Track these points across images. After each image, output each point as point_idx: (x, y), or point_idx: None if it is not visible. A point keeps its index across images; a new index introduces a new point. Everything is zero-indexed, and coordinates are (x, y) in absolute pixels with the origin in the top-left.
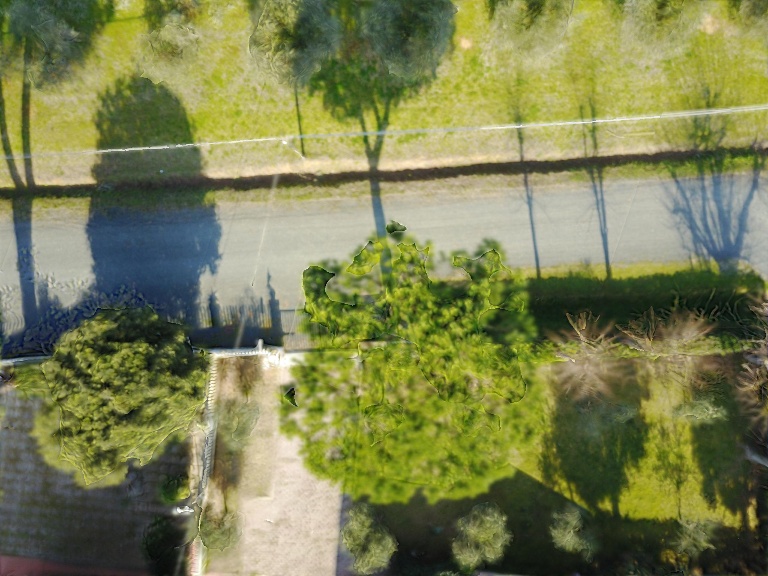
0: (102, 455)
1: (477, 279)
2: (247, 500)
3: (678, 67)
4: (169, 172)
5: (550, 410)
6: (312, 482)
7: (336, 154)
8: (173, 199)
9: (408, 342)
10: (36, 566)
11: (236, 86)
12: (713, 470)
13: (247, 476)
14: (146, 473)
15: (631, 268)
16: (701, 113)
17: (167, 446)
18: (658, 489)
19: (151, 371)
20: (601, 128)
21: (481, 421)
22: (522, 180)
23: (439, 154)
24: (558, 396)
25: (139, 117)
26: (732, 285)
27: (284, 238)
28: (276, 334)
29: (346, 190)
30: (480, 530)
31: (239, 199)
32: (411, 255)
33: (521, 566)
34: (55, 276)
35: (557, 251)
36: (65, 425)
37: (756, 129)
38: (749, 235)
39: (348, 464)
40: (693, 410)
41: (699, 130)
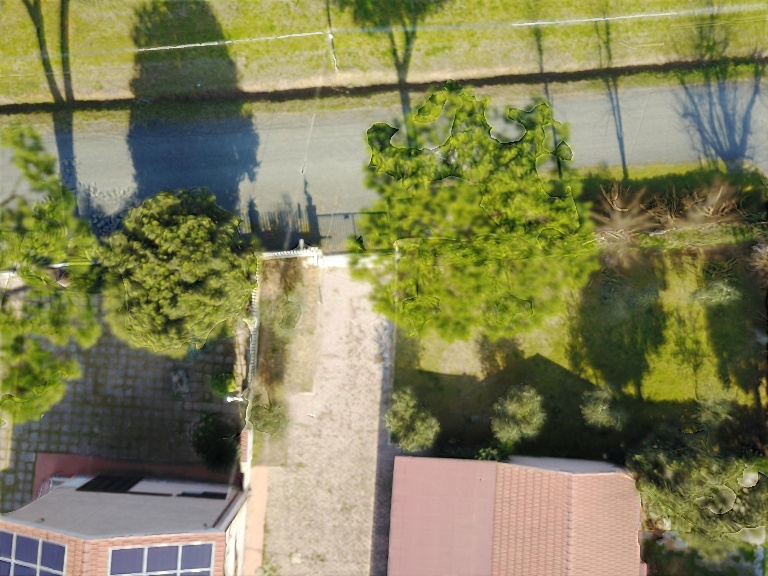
0: (168, 324)
1: (532, 127)
2: (289, 396)
3: None
4: (206, 86)
5: (575, 302)
6: (352, 377)
7: (367, 67)
8: (211, 111)
9: (442, 238)
10: (84, 466)
11: (270, 3)
12: (726, 352)
13: (289, 373)
14: (191, 373)
15: (646, 169)
16: (706, 24)
17: (211, 346)
18: (676, 372)
19: (214, 243)
20: (615, 40)
21: (514, 307)
22: (543, 89)
23: (465, 66)
24: (582, 289)
25: (176, 33)
26: (738, 183)
27: (319, 146)
28: (314, 238)
29: (378, 100)
30: (517, 405)
31: (275, 110)
32: (472, 104)
33: (551, 449)
34: (97, 186)
35: (577, 154)
36: (133, 295)
37: (756, 39)
38: (752, 136)
39: (386, 359)
40: (709, 290)
41: (704, 40)
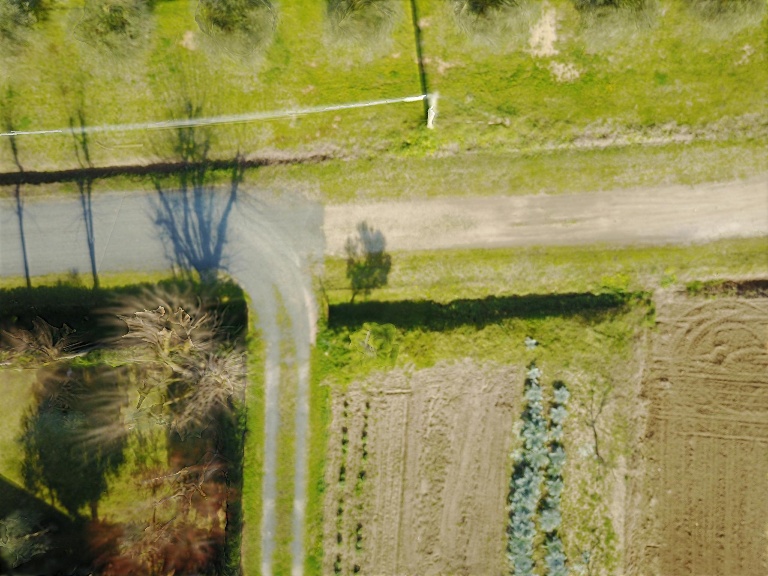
0: None
1: None
2: None
3: (162, 81)
4: None
5: (34, 417)
6: None
7: None
8: None
9: None
10: None
11: None
12: None
13: None
14: None
15: (118, 277)
16: (184, 126)
17: None
18: (136, 493)
19: None
20: (92, 140)
21: None
22: (14, 190)
23: None
24: (42, 403)
25: None
26: (213, 293)
27: None
28: None
29: None
30: None
31: None
32: None
33: (3, 571)
34: None
35: (46, 260)
36: None
37: (237, 142)
38: (228, 245)
39: None
40: None
41: (184, 143)
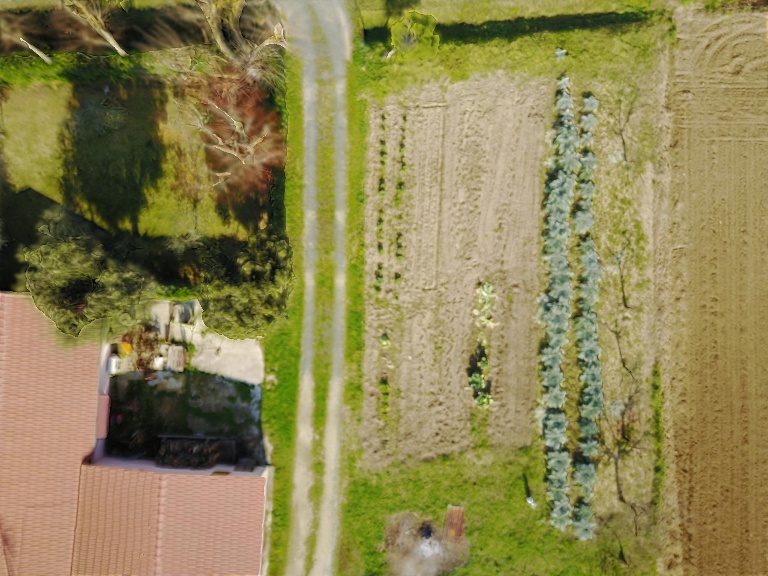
0: None
1: None
2: None
3: None
4: None
5: (71, 135)
6: None
7: None
8: None
9: None
10: None
11: None
12: (227, 187)
13: None
14: None
15: None
16: None
17: None
18: (176, 208)
19: None
20: None
21: None
22: None
23: None
24: None
25: None
26: (249, 15)
27: None
28: None
29: None
30: None
31: None
32: None
33: None
34: None
35: None
36: None
37: None
38: None
39: None
40: None
41: None
